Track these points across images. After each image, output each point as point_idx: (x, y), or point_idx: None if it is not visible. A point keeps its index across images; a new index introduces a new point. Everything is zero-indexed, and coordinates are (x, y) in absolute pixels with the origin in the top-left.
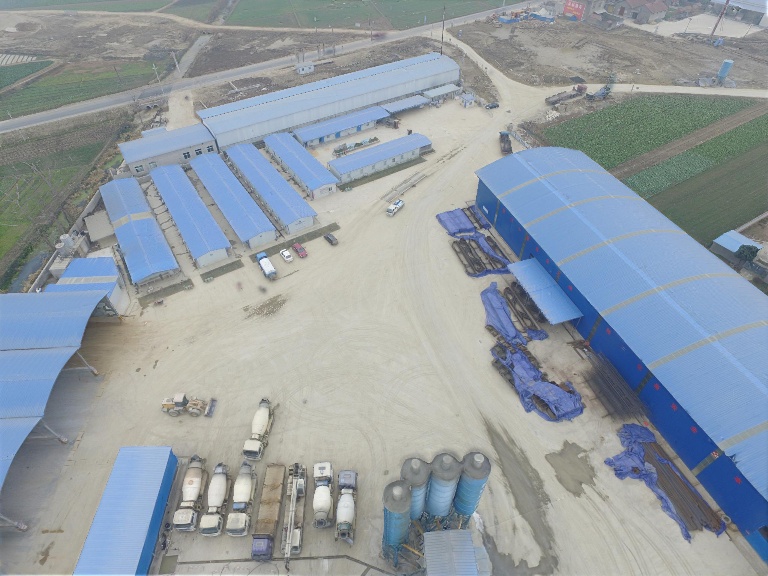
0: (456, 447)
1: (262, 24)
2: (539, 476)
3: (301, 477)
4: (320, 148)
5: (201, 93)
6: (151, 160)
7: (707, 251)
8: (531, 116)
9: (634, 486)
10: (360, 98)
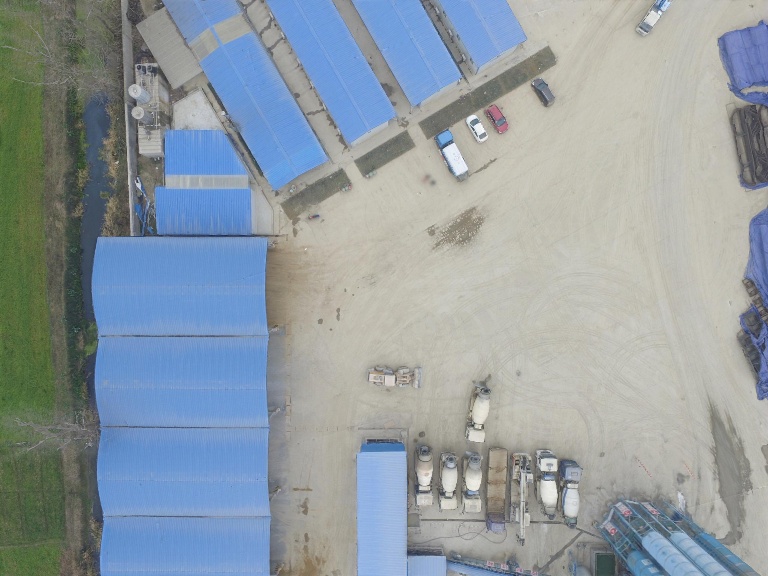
0: (675, 433)
1: None
2: (749, 466)
3: (527, 467)
4: None
5: None
6: None
7: None
8: None
9: None
10: None
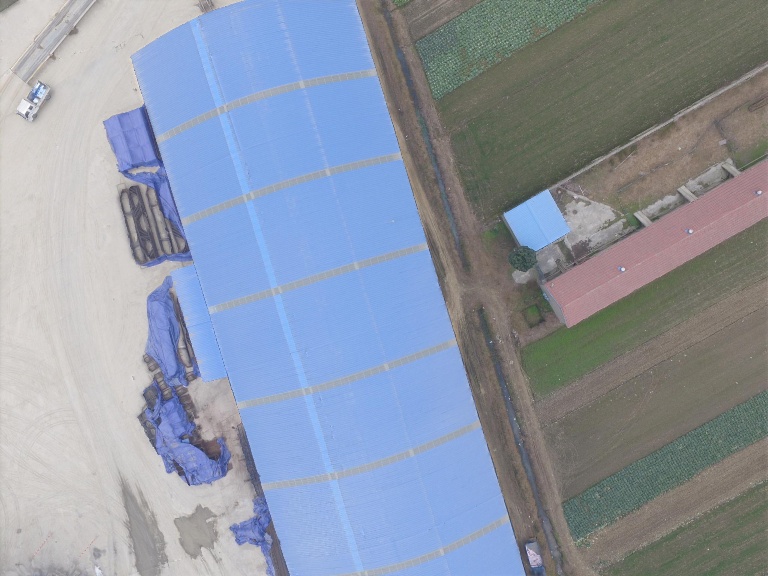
0: (88, 508)
1: None
2: (163, 539)
3: None
4: None
5: None
6: None
7: (434, 292)
8: None
9: (249, 551)
10: None
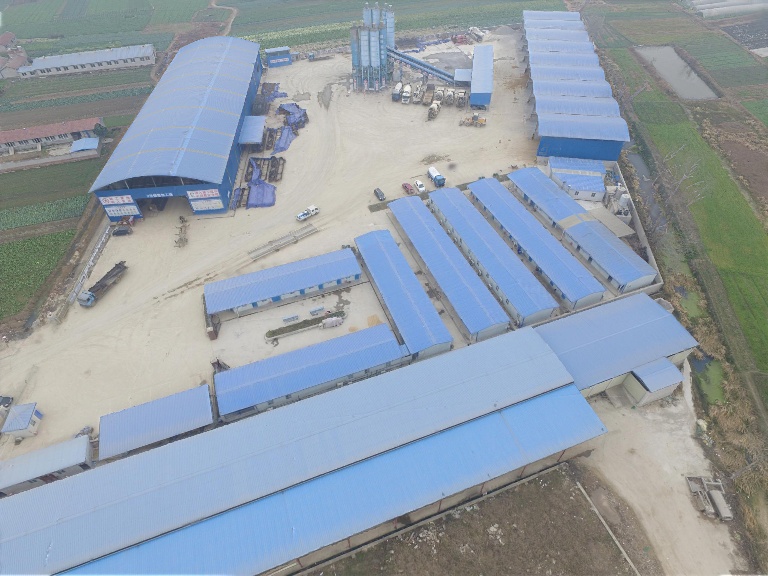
0: None
1: None
2: None
3: None
4: None
5: None
6: None
7: None
8: None
9: None
10: None
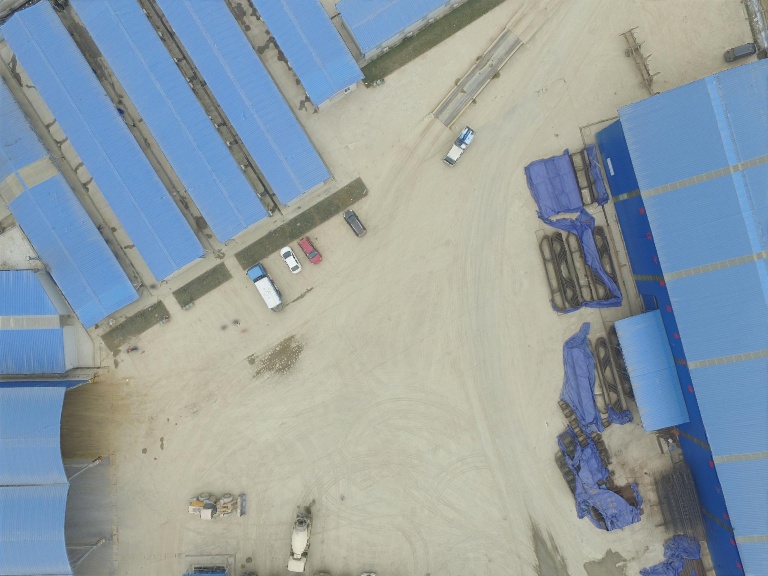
0: (498, 553)
1: None
2: None
3: None
4: None
5: None
6: None
7: None
8: None
9: None
10: None
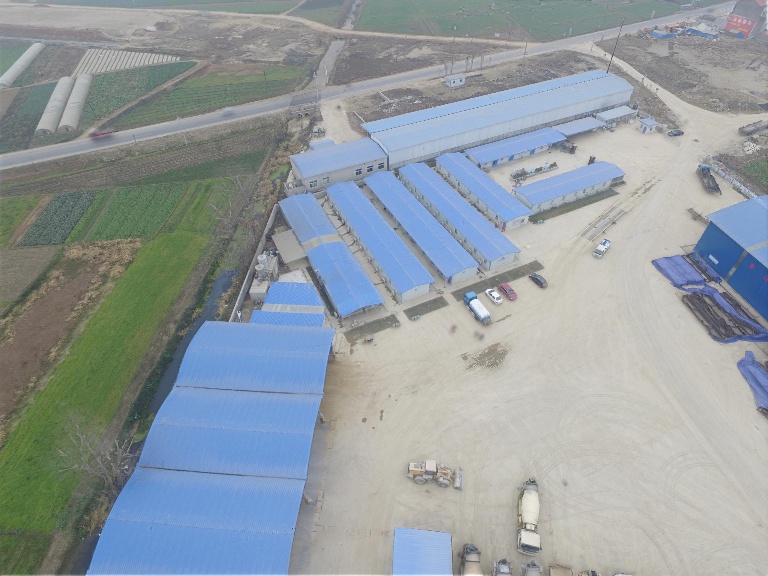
0: None
1: (393, 30)
2: None
3: None
4: (494, 171)
5: (352, 103)
6: (326, 175)
7: None
8: (725, 147)
9: None
10: (531, 118)
